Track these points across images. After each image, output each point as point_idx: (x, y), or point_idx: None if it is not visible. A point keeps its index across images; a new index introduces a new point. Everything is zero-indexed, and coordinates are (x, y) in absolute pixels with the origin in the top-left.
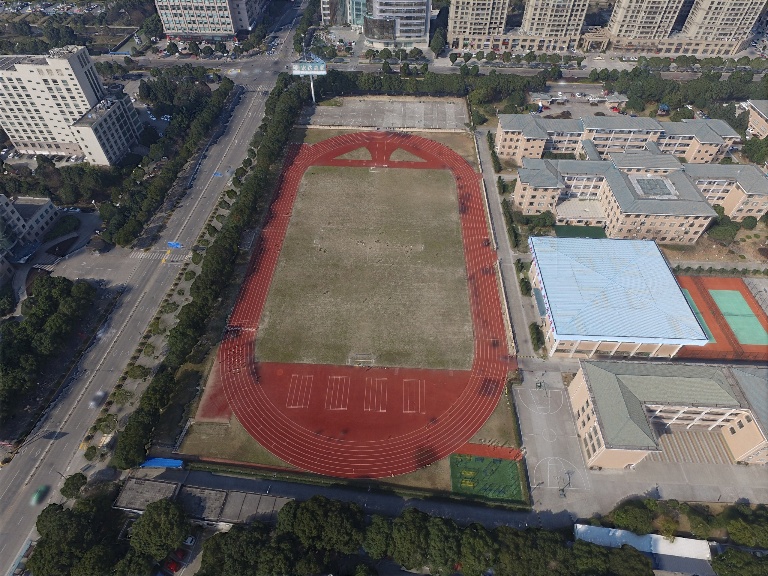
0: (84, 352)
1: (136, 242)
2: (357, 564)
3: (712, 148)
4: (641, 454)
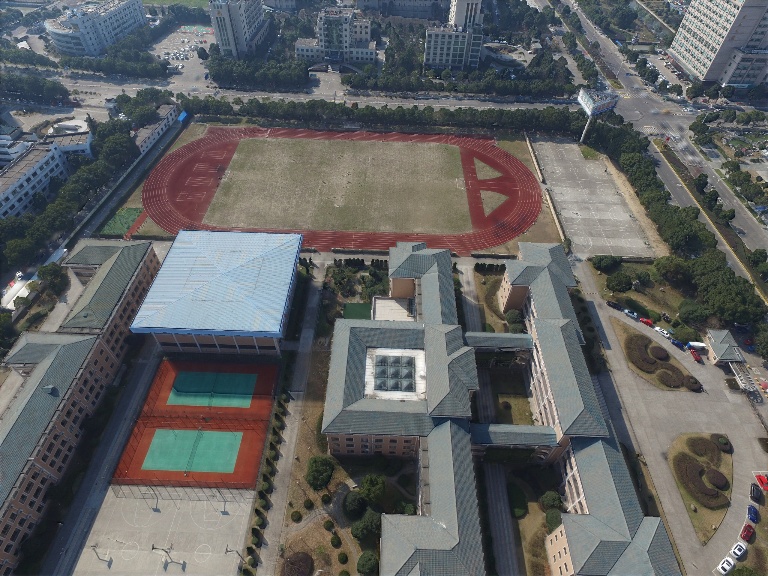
0: (265, 91)
1: (353, 90)
2: (93, 161)
3: None
4: None
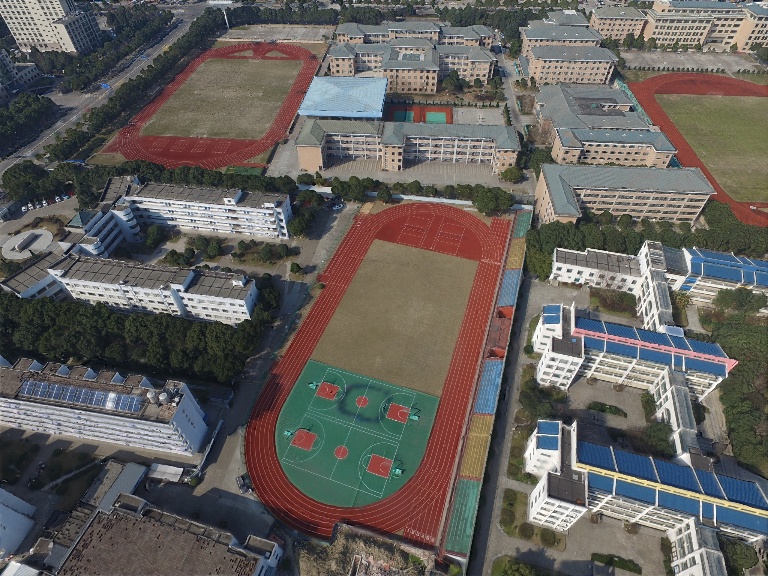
0: (44, 131)
1: (86, 90)
2: None
3: (474, 43)
4: (318, 154)
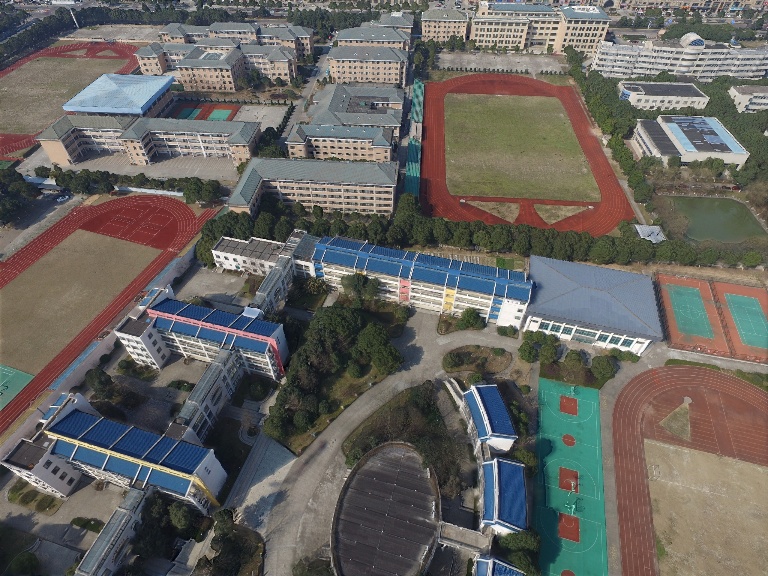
0: None
1: None
2: None
3: (290, 44)
4: (61, 148)
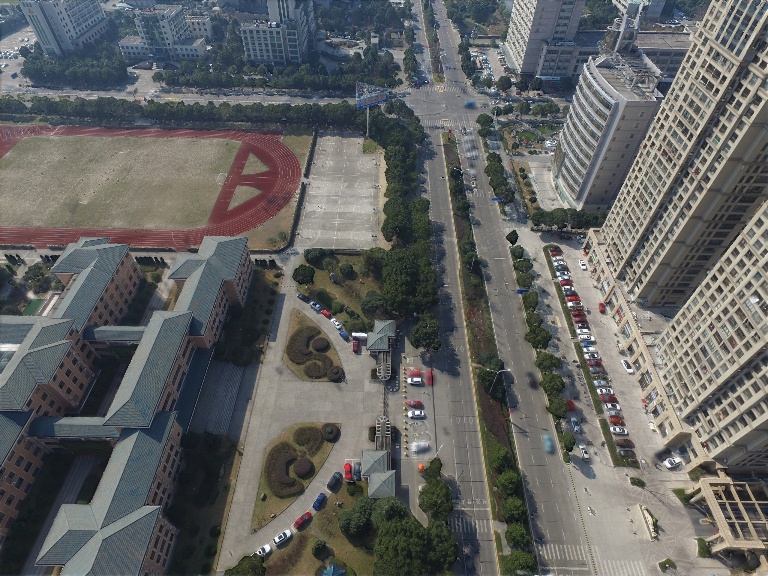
0: (76, 89)
1: (167, 87)
2: None
3: None
4: None
